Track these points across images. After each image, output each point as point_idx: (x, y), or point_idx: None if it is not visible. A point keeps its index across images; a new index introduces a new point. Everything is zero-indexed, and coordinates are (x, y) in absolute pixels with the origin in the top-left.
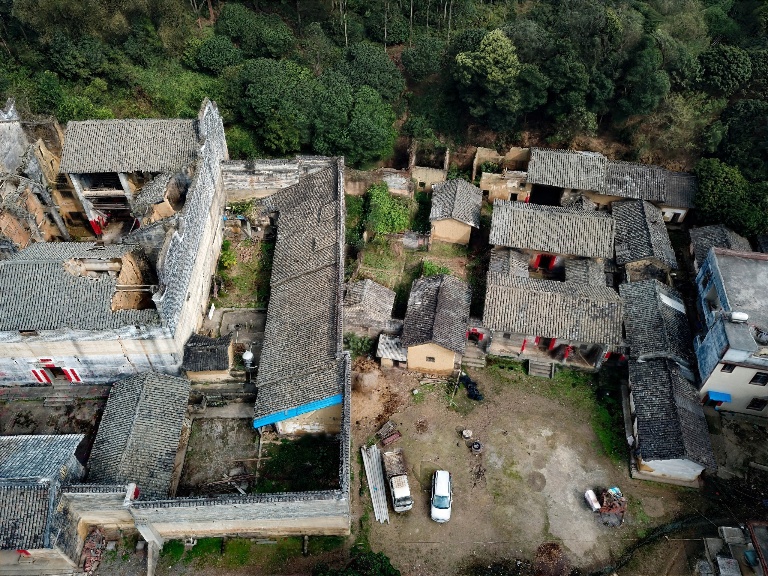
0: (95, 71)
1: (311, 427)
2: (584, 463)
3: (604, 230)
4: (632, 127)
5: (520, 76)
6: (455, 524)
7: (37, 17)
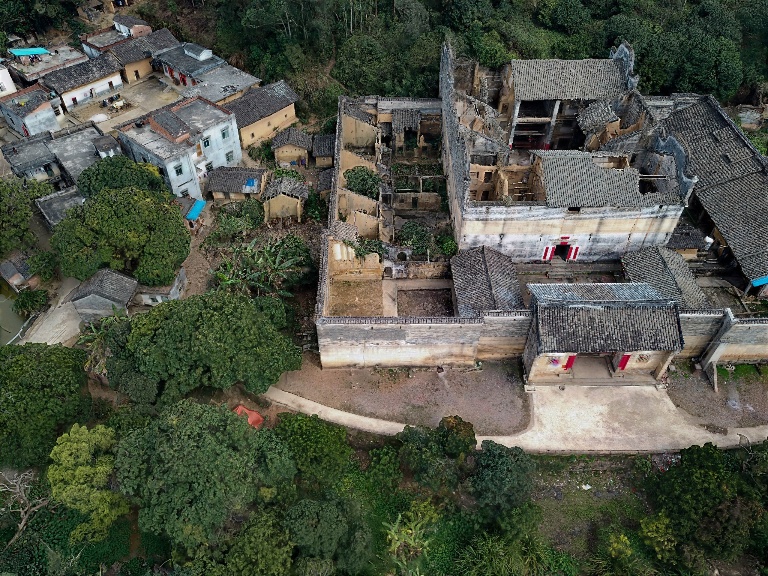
0: (483, 25)
1: None
2: None
3: None
4: None
5: None
6: None
7: None
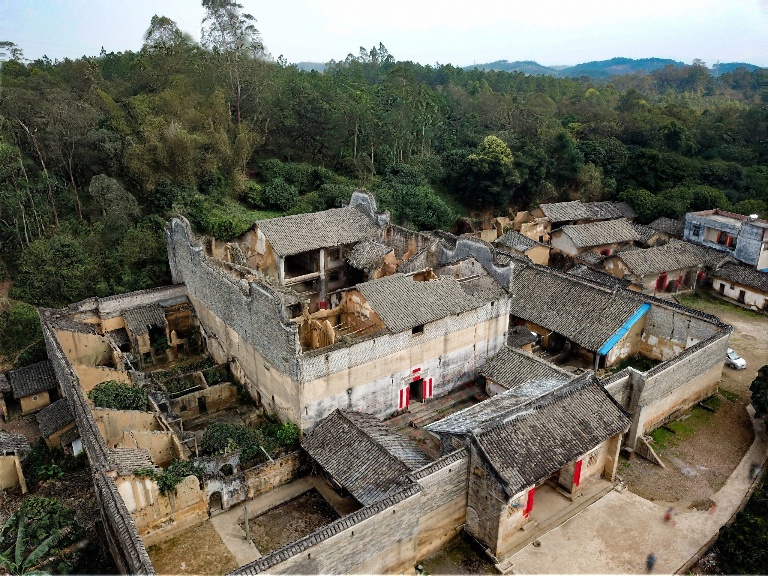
0: None
1: (624, 351)
2: (752, 324)
3: (626, 225)
4: (568, 190)
5: (515, 161)
6: (750, 367)
7: (145, 166)
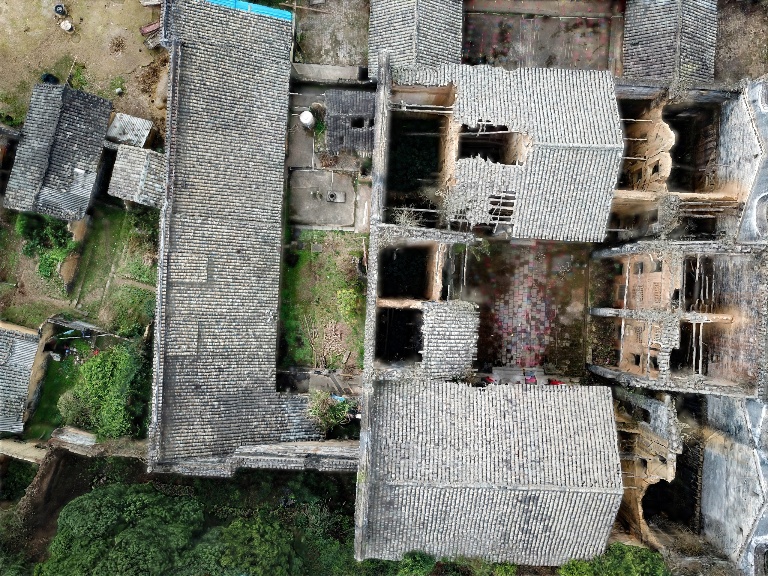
0: None
1: None
2: None
3: None
4: None
5: None
6: None
7: None
